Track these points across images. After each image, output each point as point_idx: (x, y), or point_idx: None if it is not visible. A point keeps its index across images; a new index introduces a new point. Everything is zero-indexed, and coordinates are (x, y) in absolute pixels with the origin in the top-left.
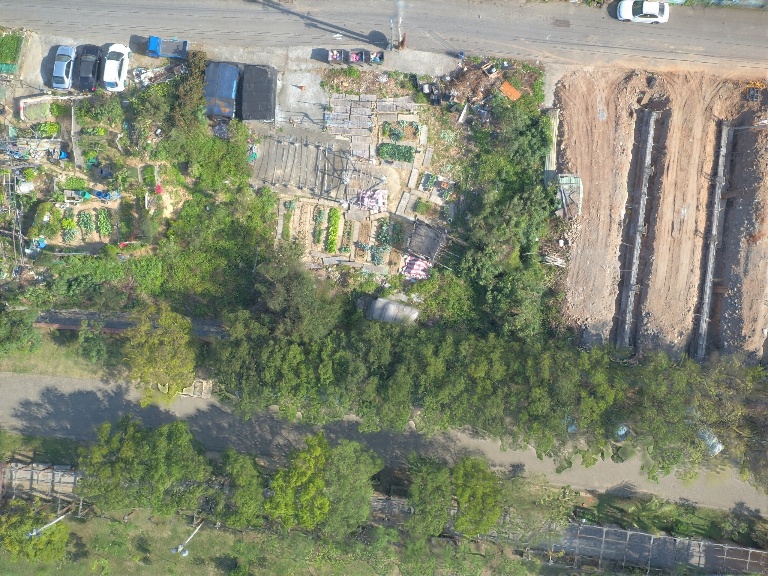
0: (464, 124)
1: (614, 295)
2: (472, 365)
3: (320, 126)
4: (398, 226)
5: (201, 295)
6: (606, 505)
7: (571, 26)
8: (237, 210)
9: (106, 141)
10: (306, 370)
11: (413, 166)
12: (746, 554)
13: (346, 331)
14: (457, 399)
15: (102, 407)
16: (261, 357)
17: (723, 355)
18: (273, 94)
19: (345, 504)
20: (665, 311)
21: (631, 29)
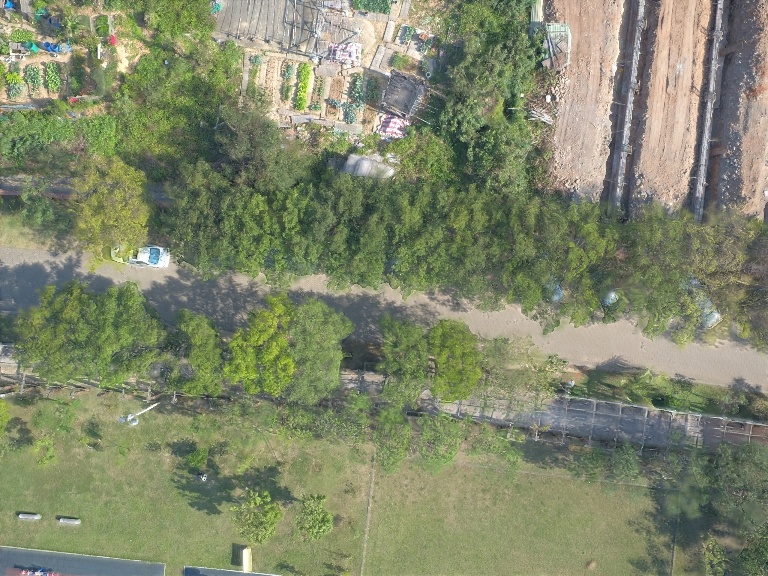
0: None
1: (605, 156)
2: (451, 214)
3: None
4: (372, 81)
5: (158, 156)
6: (597, 382)
7: None
8: (198, 65)
9: None
10: (269, 219)
11: (389, 18)
12: (748, 428)
13: None
14: (435, 251)
15: (50, 279)
16: (220, 206)
17: (722, 220)
18: None
19: (312, 365)
20: (659, 173)
21: None
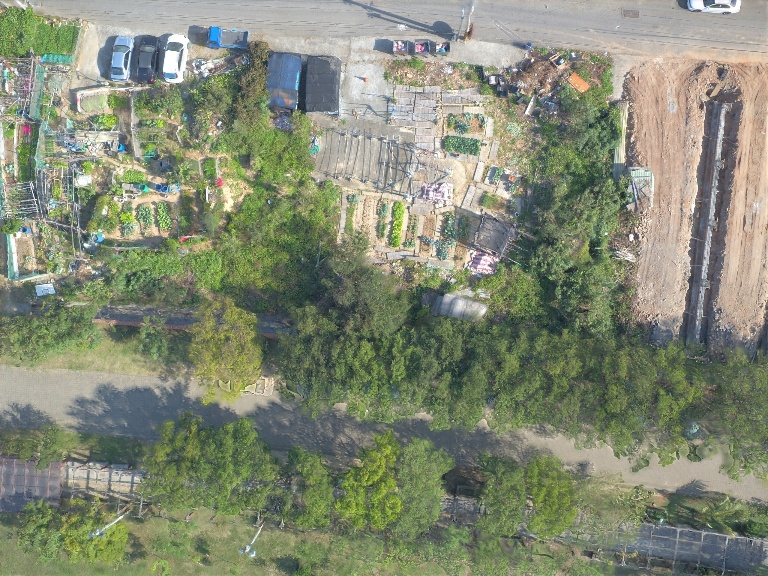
0: (531, 116)
1: (685, 291)
2: (547, 362)
3: (384, 118)
4: (464, 220)
5: (262, 290)
6: (677, 505)
7: (640, 16)
8: (299, 204)
9: (165, 133)
10: (377, 367)
11: (479, 159)
12: None
13: (415, 327)
14: (532, 396)
15: (160, 405)
16: (331, 353)
17: None
18: (337, 85)
19: (418, 504)
20: (737, 307)
21: (701, 20)
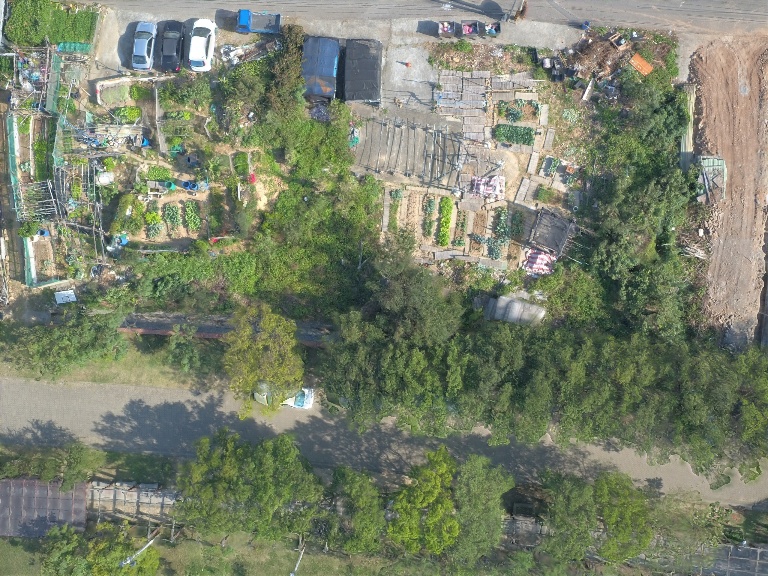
0: (589, 102)
1: (759, 289)
2: (617, 370)
3: (428, 106)
4: (518, 216)
5: (300, 295)
6: (753, 522)
7: None
8: (338, 200)
9: (192, 126)
10: (431, 377)
11: (533, 149)
12: None
13: (469, 333)
14: (601, 408)
15: (191, 419)
16: (380, 363)
17: None
18: (379, 71)
19: (478, 527)
20: None
21: None
